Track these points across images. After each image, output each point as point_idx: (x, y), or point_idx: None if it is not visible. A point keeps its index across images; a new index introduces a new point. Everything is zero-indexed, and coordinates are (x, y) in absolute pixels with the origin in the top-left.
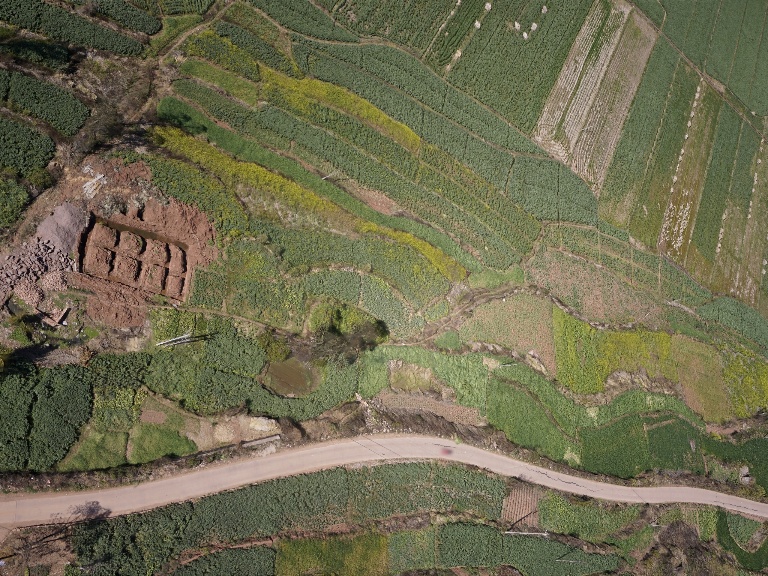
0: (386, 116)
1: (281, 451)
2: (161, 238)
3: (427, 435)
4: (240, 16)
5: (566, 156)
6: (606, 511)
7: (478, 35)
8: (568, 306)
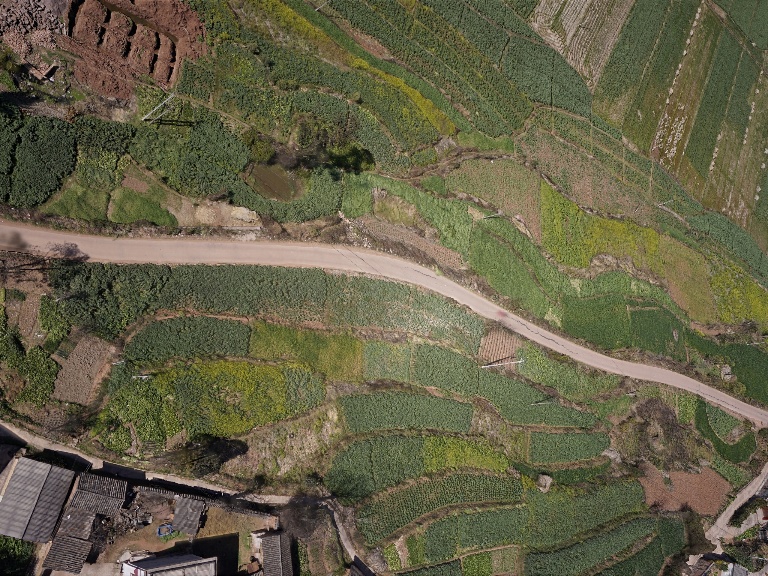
0: None
1: (261, 241)
2: (151, 26)
3: (408, 260)
4: None
5: (562, 47)
6: (584, 374)
7: None
8: (557, 184)
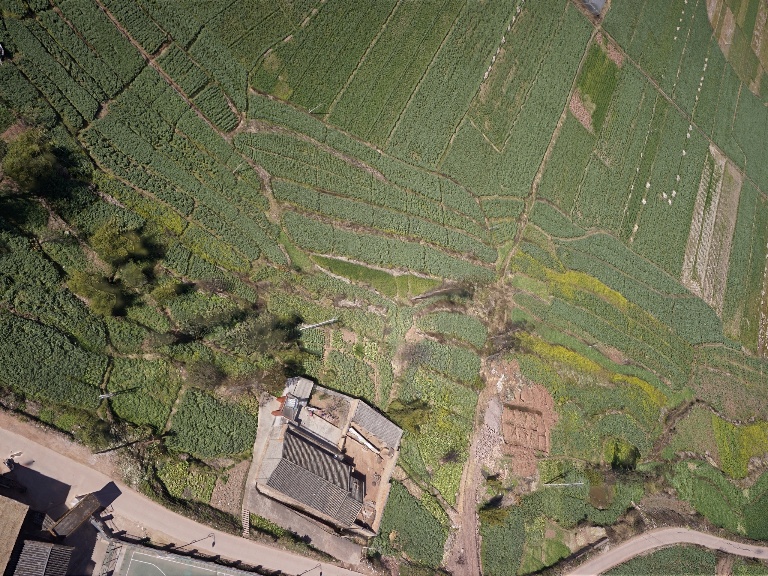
0: (608, 288)
1: (611, 549)
2: (530, 410)
3: (674, 526)
4: (530, 234)
5: (700, 290)
6: (766, 568)
7: (645, 209)
8: (719, 411)
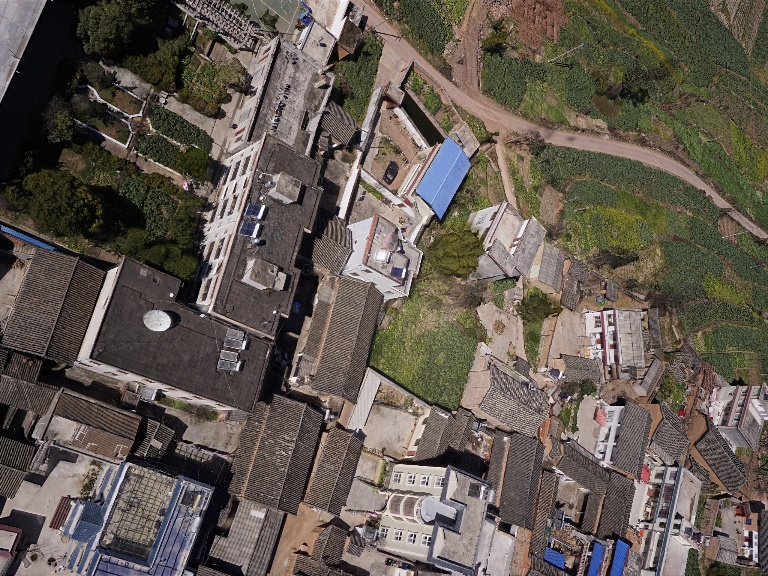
0: None
1: (612, 140)
2: None
3: (678, 162)
4: None
5: (728, 25)
6: None
7: None
8: None
